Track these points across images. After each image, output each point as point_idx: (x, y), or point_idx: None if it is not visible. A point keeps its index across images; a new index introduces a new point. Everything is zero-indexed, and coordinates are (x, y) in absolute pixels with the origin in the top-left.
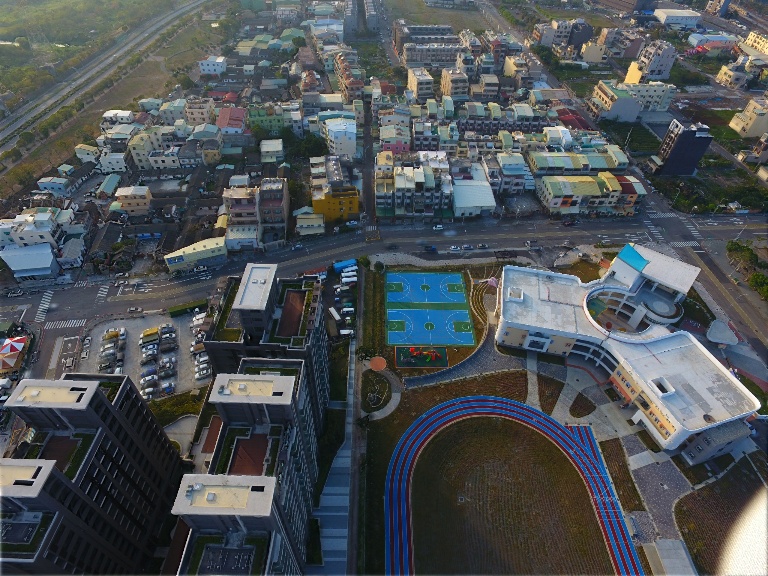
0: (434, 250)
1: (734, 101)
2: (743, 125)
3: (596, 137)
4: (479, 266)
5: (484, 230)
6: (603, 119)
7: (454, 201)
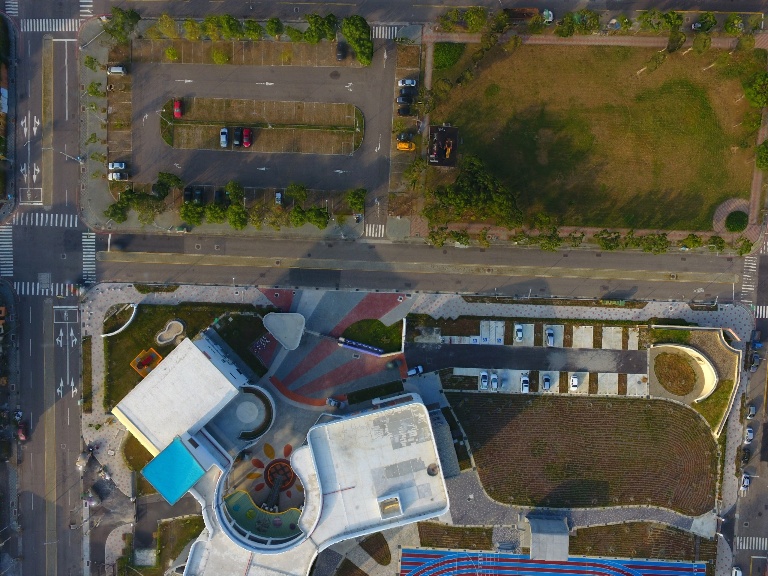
0: None
1: None
2: None
3: None
4: None
5: None
6: None
7: None
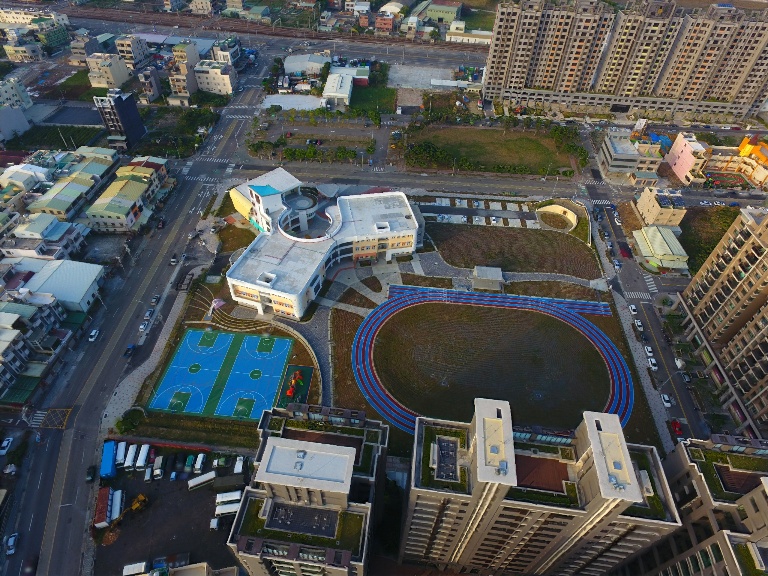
0: (134, 348)
1: (60, 69)
2: (105, 80)
3: (48, 155)
4: (185, 310)
5: (127, 292)
6: (4, 143)
7: (66, 302)
